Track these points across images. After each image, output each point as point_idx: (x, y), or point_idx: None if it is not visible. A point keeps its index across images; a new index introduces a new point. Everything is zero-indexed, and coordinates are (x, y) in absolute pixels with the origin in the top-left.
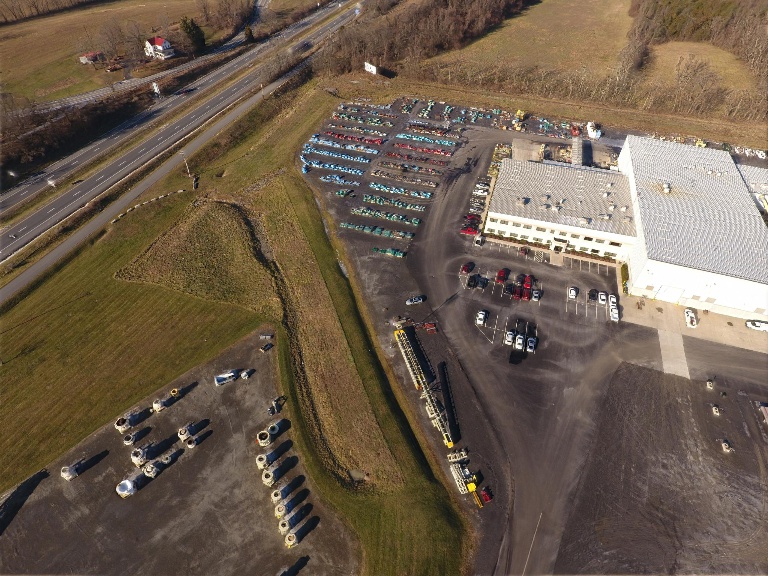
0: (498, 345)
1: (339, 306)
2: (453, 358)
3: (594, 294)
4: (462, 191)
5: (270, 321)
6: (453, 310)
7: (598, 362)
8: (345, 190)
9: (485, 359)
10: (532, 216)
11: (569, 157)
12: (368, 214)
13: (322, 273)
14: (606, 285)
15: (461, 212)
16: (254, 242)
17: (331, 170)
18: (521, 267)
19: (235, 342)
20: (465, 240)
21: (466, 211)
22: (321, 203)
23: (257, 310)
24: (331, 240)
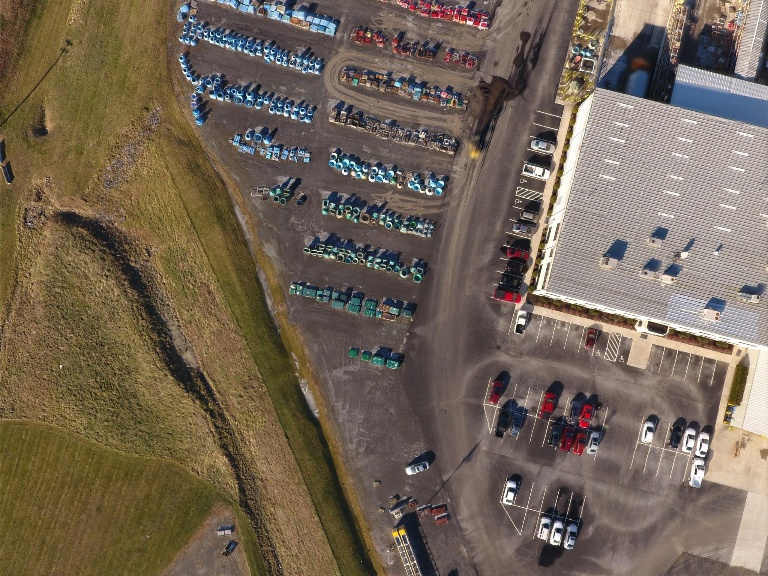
0: (528, 538)
1: (313, 485)
2: (468, 563)
3: (679, 438)
4: (503, 165)
5: (223, 500)
6: (472, 479)
7: (652, 556)
8: (285, 185)
9: (508, 562)
10: (622, 301)
11: (734, 8)
12: (334, 257)
13: (278, 415)
14: (702, 408)
15: (497, 235)
16: (158, 331)
17: (249, 110)
18: (581, 377)
19: (187, 541)
20: (499, 316)
21: (506, 231)
22: (247, 224)
23: (201, 475)
24: (280, 329)
